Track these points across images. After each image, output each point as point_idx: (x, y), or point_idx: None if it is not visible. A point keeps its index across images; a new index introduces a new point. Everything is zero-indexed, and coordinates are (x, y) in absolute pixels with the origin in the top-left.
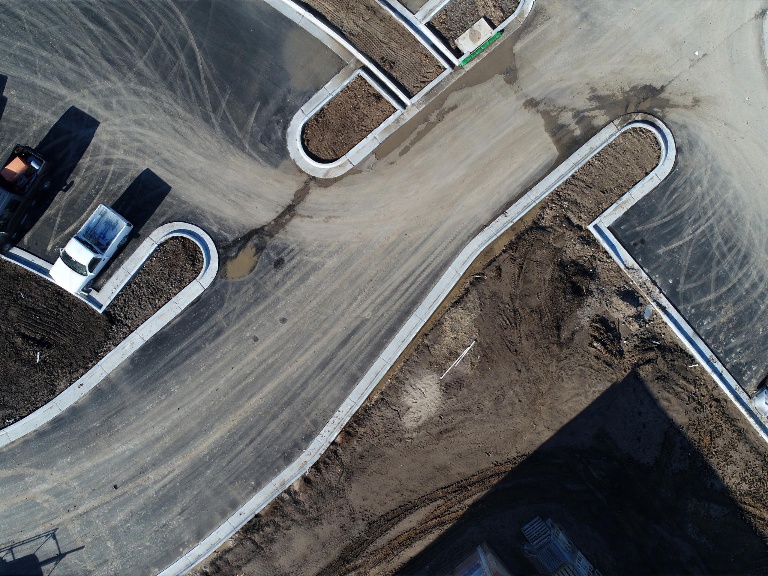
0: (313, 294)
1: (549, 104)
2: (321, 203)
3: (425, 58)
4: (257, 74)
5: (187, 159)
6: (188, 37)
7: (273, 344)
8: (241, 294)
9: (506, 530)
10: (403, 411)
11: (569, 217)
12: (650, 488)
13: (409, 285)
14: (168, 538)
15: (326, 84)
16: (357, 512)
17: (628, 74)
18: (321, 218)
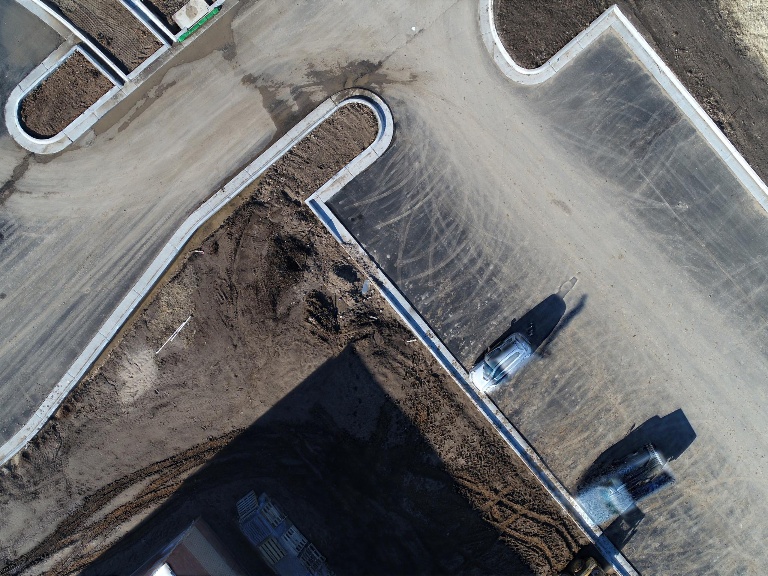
0: (32, 269)
1: (267, 80)
2: (40, 179)
3: (142, 34)
4: None
5: None
6: None
7: None
8: None
9: (222, 504)
10: (120, 386)
11: (287, 192)
12: (366, 462)
13: (128, 260)
14: None
15: (44, 60)
16: (73, 486)
17: (345, 50)
18: (40, 194)
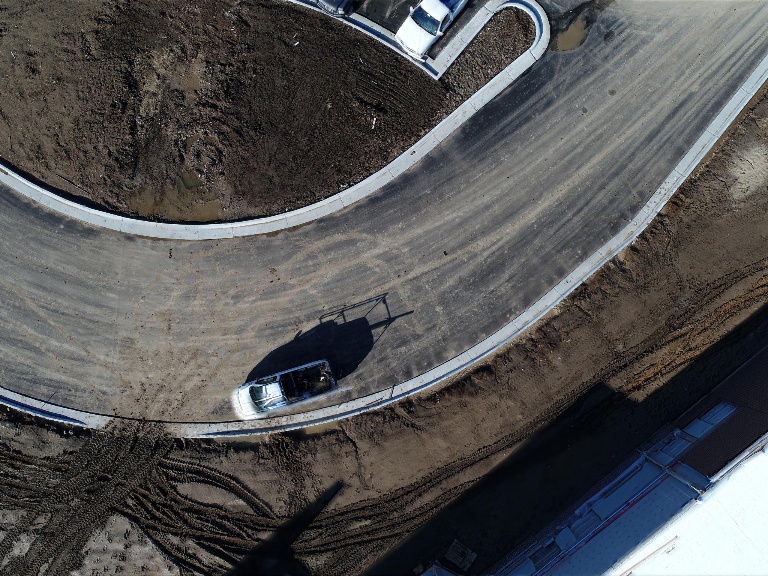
0: (642, 67)
1: None
2: None
3: None
4: None
5: None
6: None
7: (602, 116)
8: (571, 66)
9: None
10: (730, 182)
11: None
12: None
13: (736, 60)
14: (495, 304)
15: None
16: (684, 280)
17: None
18: None
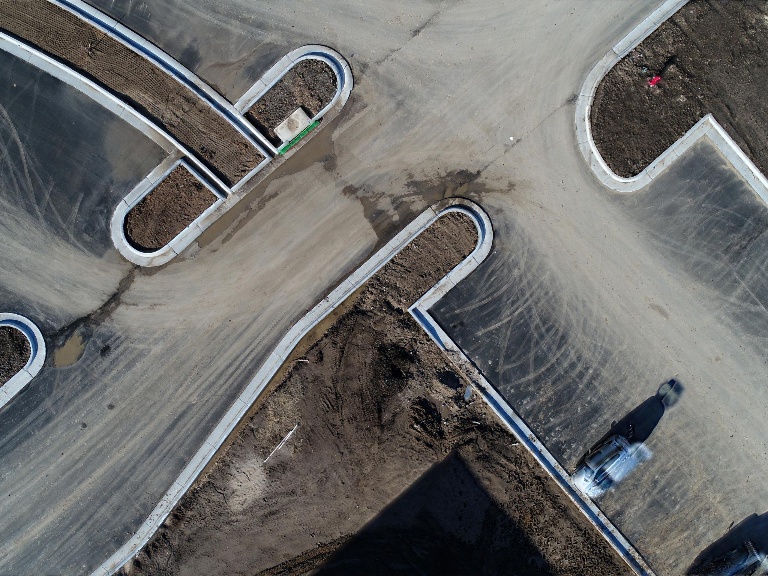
0: (139, 380)
1: (368, 190)
2: (146, 291)
3: (245, 148)
4: (80, 166)
5: (12, 251)
6: (11, 131)
7: (101, 430)
8: (69, 382)
9: None
10: (228, 494)
11: (389, 301)
12: (472, 565)
13: (234, 370)
14: None
15: (148, 175)
16: None
17: (445, 160)
18: (146, 306)
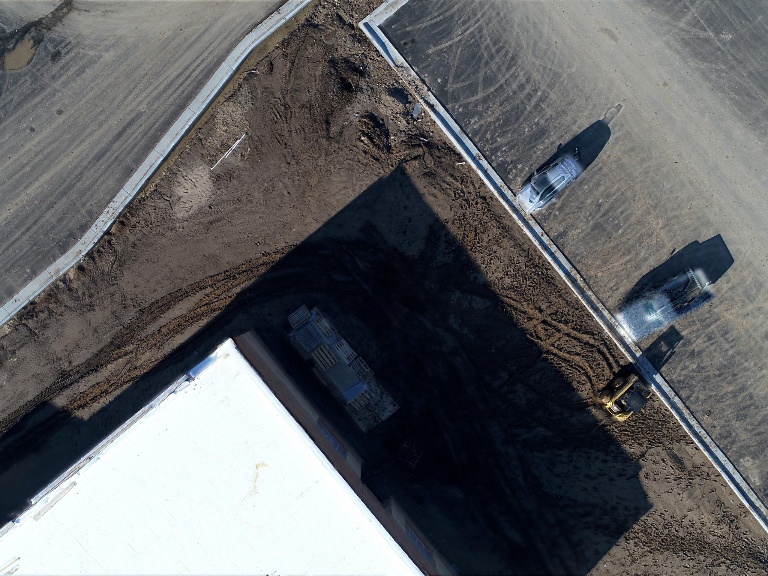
0: (89, 86)
1: None
2: None
3: None
4: None
5: None
6: None
7: (49, 135)
8: (18, 85)
9: (273, 318)
10: (175, 201)
11: (341, 15)
12: (414, 280)
13: (184, 79)
14: None
15: None
16: (128, 299)
17: None
18: (98, 12)
